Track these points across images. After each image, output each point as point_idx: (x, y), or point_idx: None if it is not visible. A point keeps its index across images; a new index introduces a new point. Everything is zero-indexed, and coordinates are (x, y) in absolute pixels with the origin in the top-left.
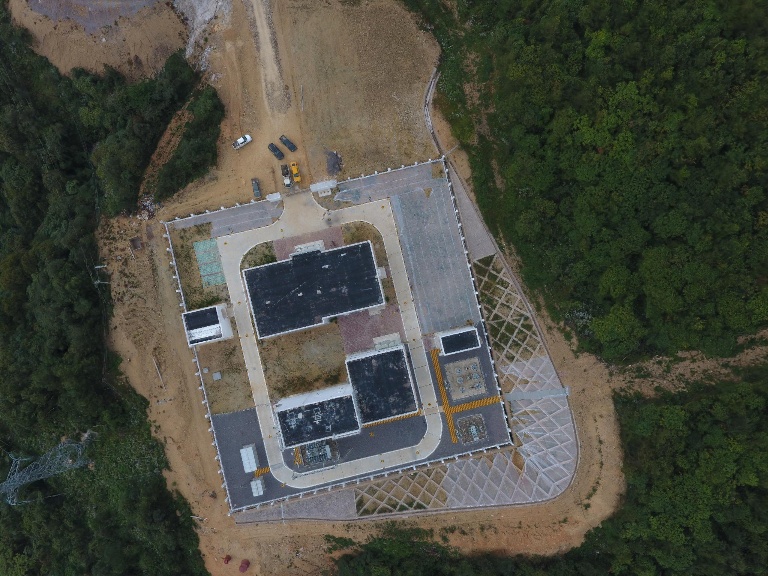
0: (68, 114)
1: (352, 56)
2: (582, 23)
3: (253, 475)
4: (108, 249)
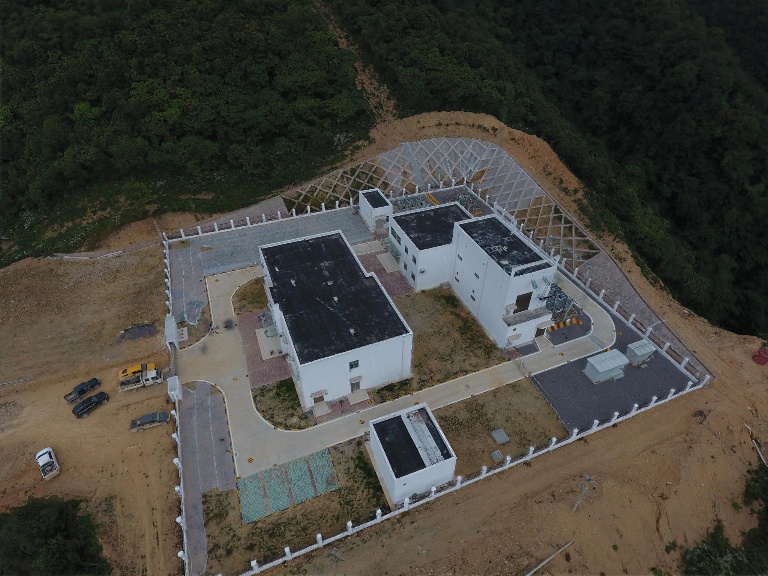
0: None
1: None
2: None
3: (629, 367)
4: None
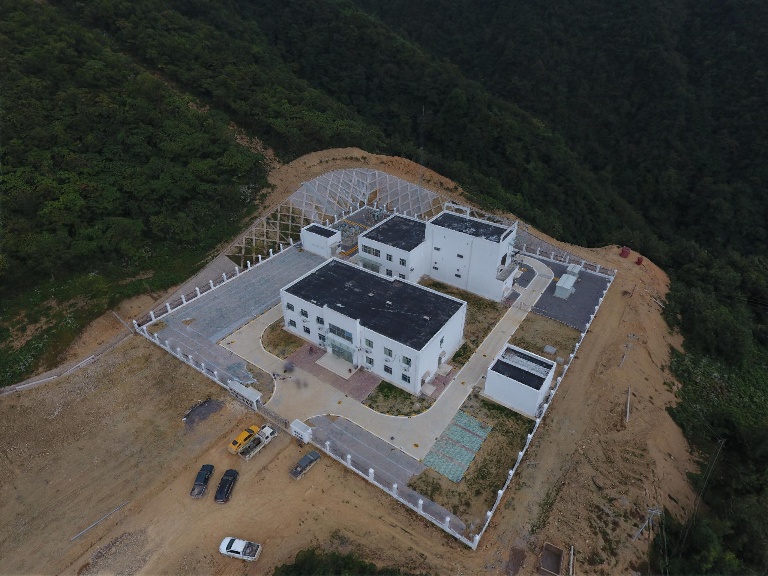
0: None
1: None
2: None
3: None
4: None
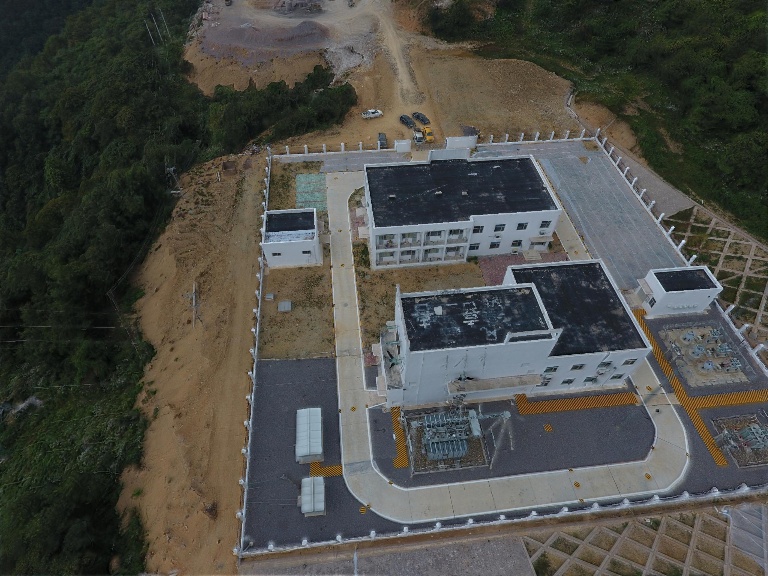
0: (196, 118)
1: (487, 80)
2: (732, 22)
3: None
4: (191, 177)
